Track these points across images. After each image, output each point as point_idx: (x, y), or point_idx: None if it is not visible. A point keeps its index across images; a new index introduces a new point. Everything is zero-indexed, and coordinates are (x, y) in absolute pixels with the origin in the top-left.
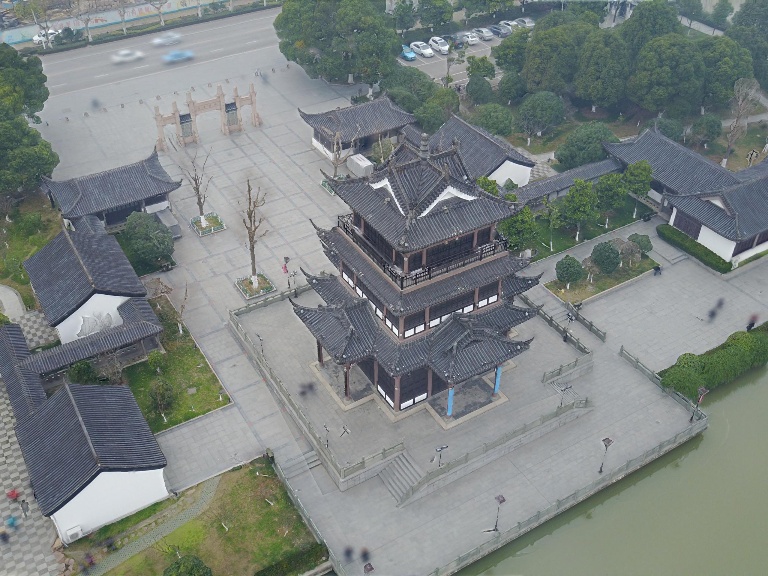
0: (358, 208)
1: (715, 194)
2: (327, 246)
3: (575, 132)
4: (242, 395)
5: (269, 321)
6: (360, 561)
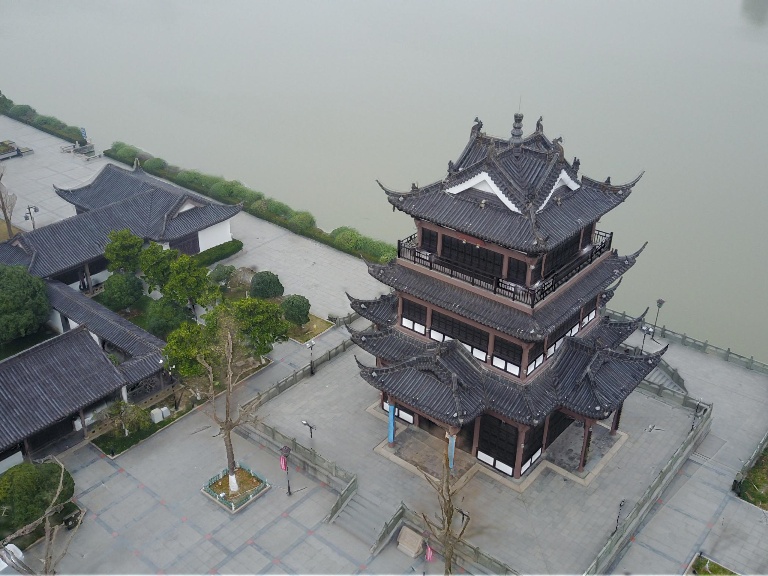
0: (569, 231)
1: (184, 201)
2: (284, 569)
3: (1, 290)
4: (677, 552)
5: (535, 560)
6: (763, 401)
